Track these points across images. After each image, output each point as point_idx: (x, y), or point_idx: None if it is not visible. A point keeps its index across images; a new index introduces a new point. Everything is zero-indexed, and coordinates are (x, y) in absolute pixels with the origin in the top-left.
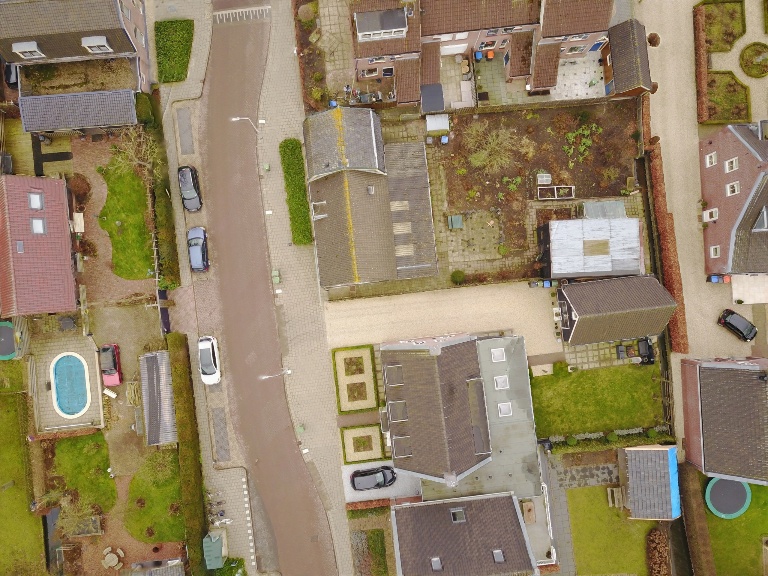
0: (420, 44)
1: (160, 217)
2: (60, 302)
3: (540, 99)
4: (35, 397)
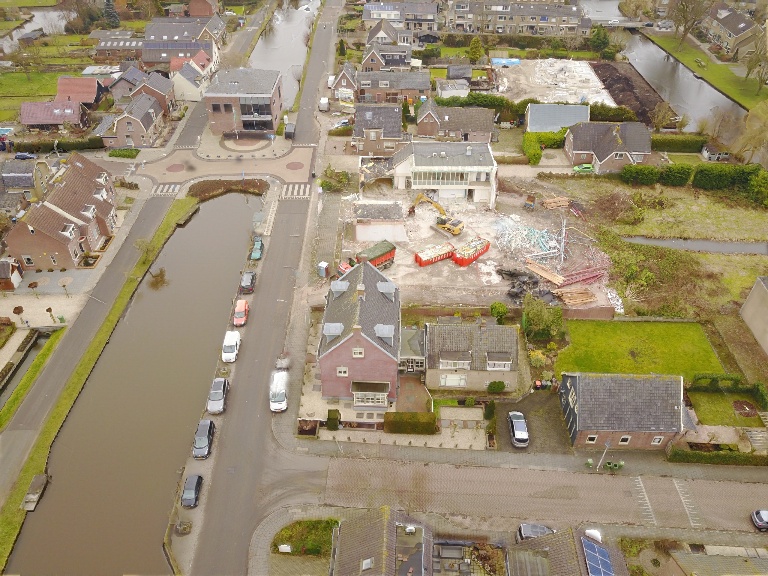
0: (49, 182)
1: (44, 141)
2: (25, 117)
3: (8, 253)
4: (1, 124)
